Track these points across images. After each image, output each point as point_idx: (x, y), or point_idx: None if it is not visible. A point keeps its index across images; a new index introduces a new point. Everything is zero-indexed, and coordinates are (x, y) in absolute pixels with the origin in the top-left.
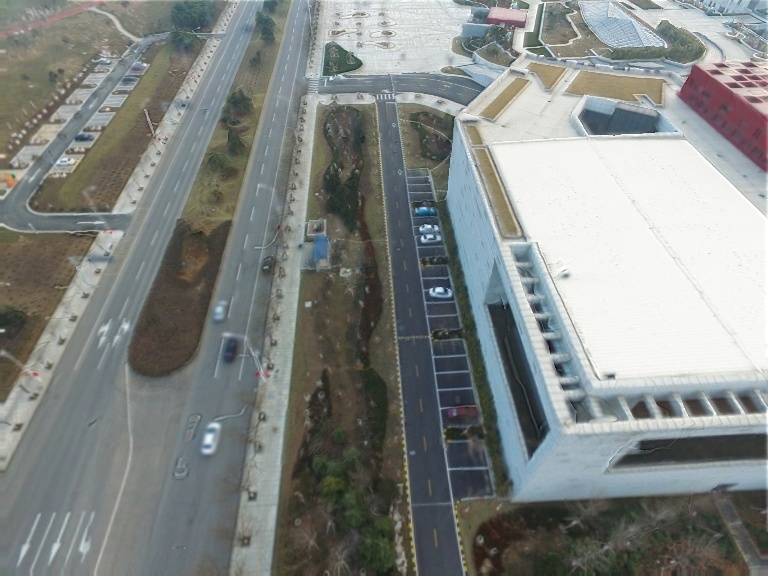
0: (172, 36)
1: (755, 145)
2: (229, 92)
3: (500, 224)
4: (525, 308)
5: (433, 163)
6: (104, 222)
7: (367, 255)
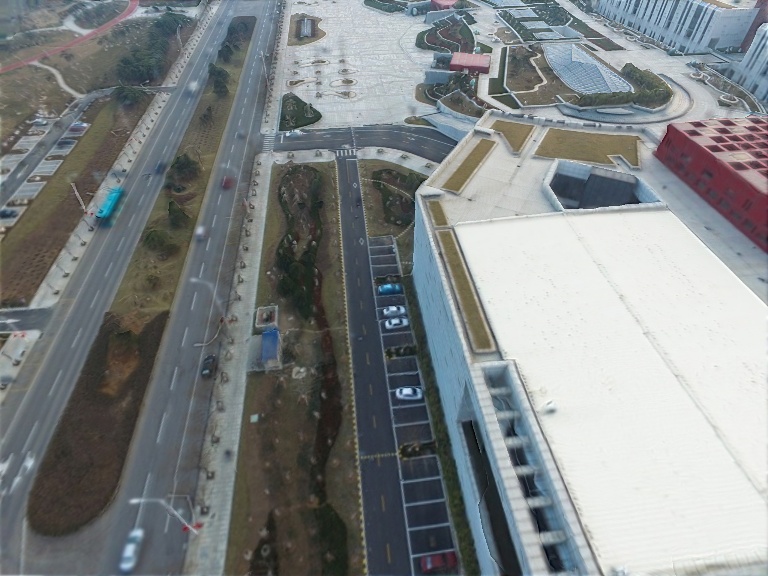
0: (117, 92)
1: (746, 217)
2: (176, 153)
3: (470, 334)
4: (505, 465)
5: (398, 229)
6: (19, 320)
7: (324, 348)
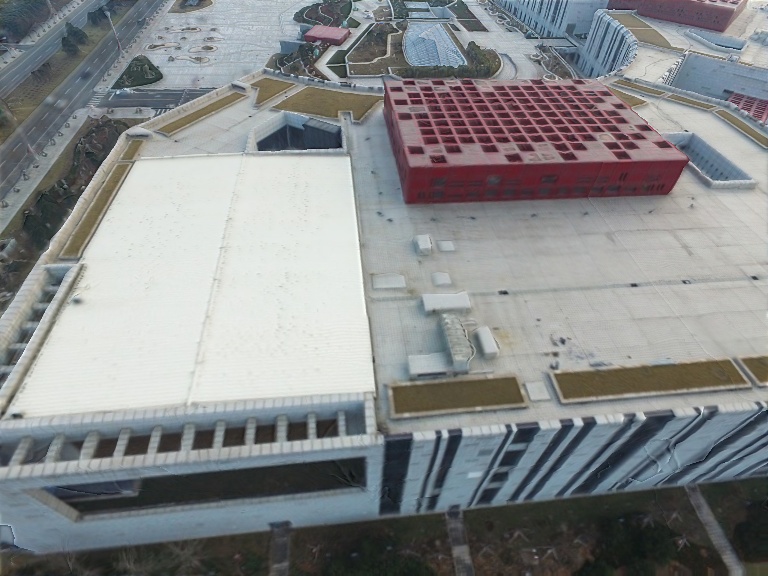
0: None
1: (399, 162)
2: None
3: (67, 244)
4: None
5: None
6: None
7: None
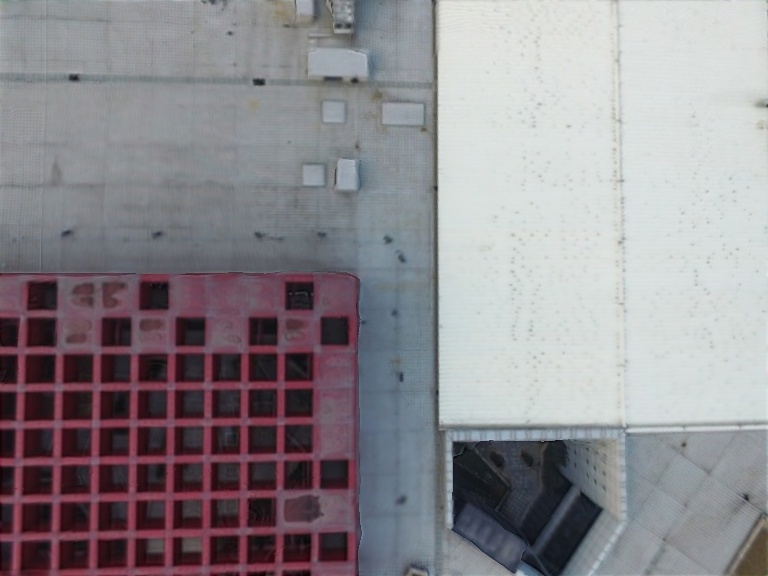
0: None
1: None
2: None
3: None
4: None
5: None
6: None
7: None
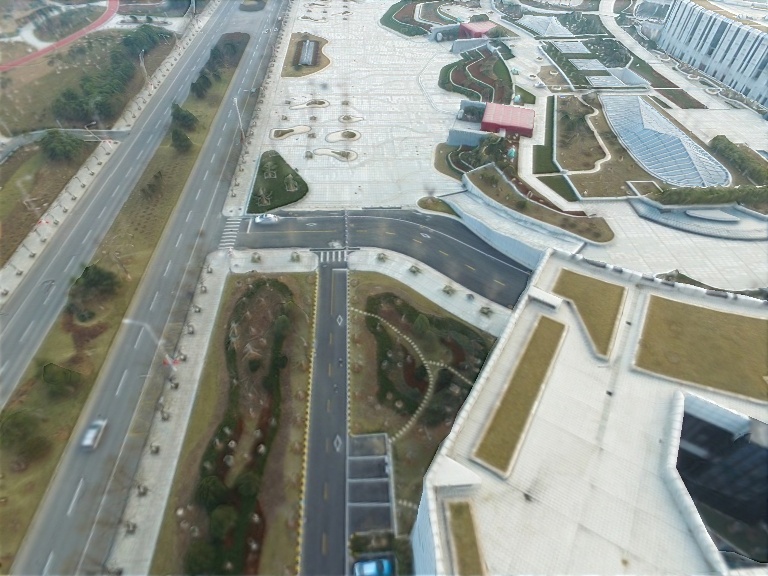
0: (46, 140)
1: None
2: (99, 245)
3: None
4: None
5: (396, 421)
6: None
7: None
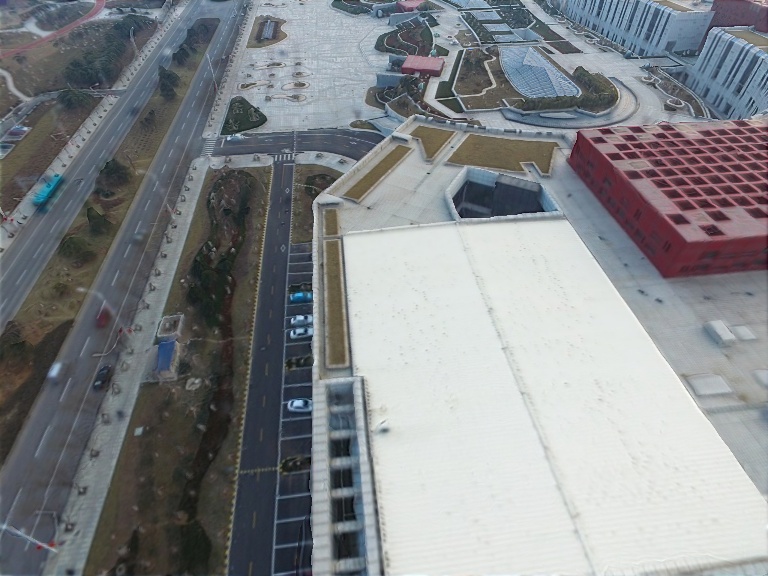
0: (62, 95)
1: (637, 227)
2: None
3: (327, 349)
4: (318, 489)
5: None
6: None
7: (223, 359)
